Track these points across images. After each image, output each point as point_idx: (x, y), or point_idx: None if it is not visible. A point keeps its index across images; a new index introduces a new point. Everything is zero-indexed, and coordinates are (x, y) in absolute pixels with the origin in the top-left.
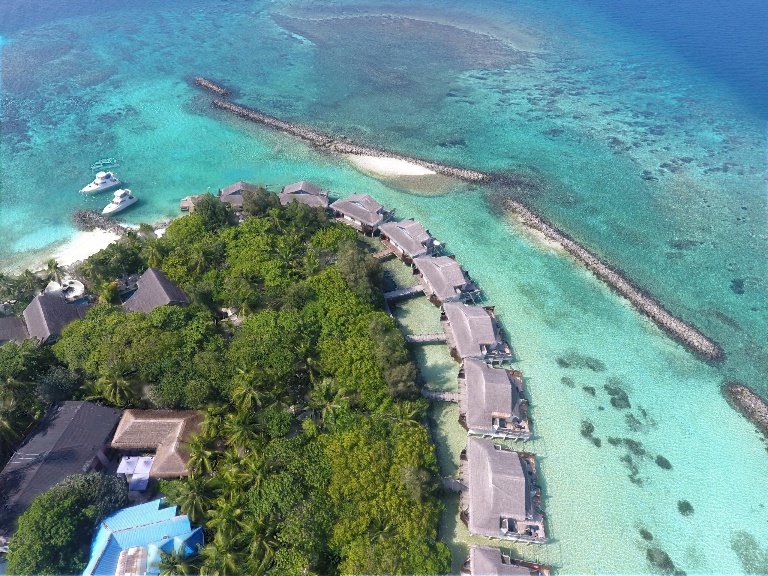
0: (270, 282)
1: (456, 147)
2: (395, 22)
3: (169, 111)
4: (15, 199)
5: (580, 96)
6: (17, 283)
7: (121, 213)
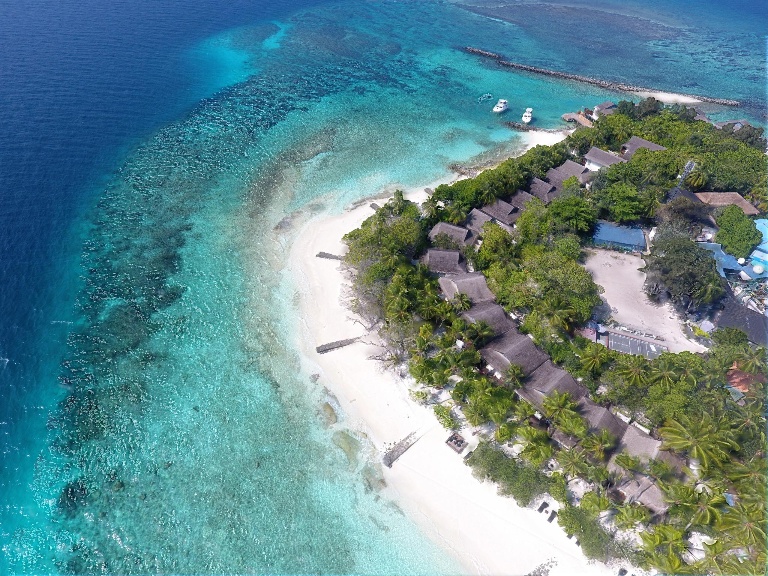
0: (706, 142)
1: (696, 87)
2: (555, 8)
3: (474, 68)
4: (452, 117)
5: (748, 56)
6: (573, 142)
7: (531, 123)
